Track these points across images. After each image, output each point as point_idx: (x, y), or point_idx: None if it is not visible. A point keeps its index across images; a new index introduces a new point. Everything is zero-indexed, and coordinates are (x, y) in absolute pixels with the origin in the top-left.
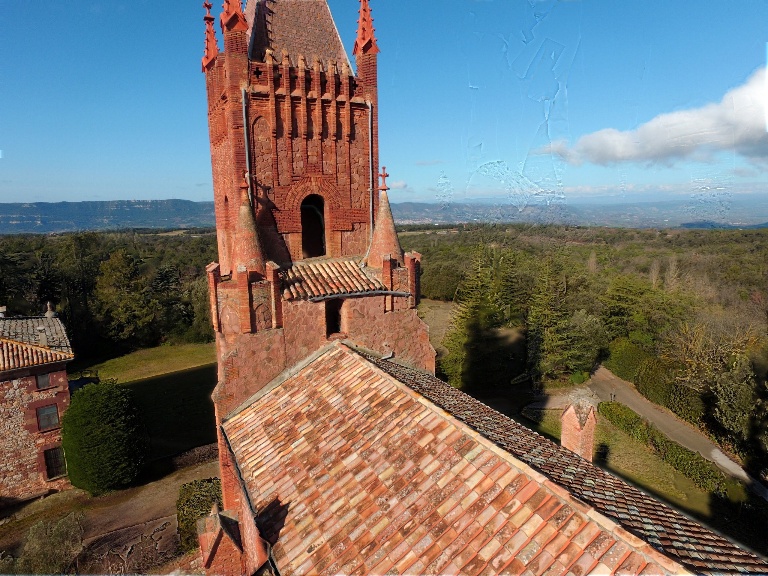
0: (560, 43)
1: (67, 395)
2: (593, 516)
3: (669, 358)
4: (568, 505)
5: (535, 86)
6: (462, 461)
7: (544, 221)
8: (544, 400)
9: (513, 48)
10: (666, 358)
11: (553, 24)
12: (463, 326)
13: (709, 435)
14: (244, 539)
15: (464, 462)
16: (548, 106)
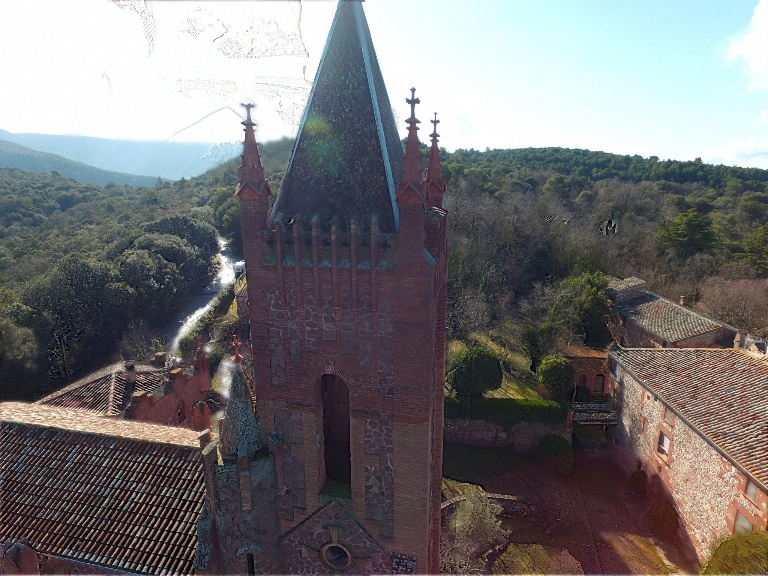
0: None
1: (764, 527)
2: None
3: None
4: None
5: None
6: None
7: None
8: None
9: None
10: None
11: None
12: None
13: None
14: None
15: None
16: None
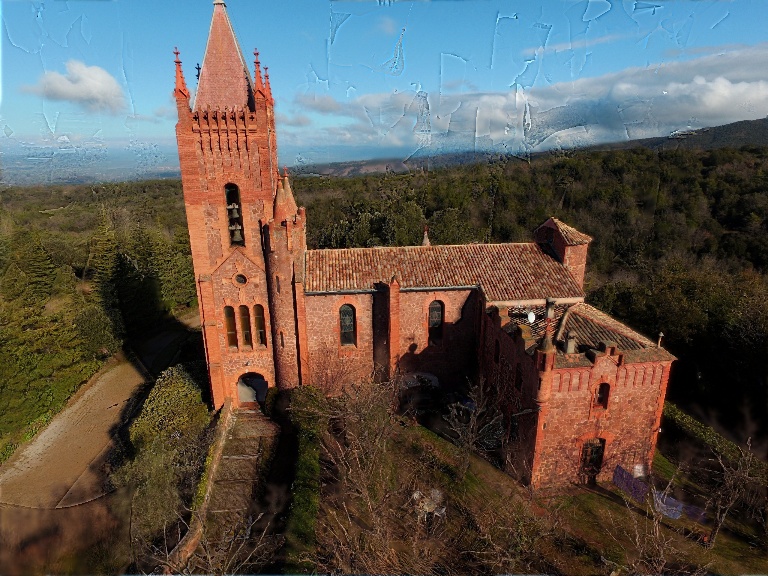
0: (103, 25)
1: None
2: (438, 246)
3: None
4: (433, 247)
5: (49, 49)
6: (407, 252)
7: (124, 186)
8: (193, 321)
9: (85, 27)
10: None
11: (91, 5)
12: (111, 286)
13: None
14: (308, 347)
15: (408, 252)
16: (47, 67)
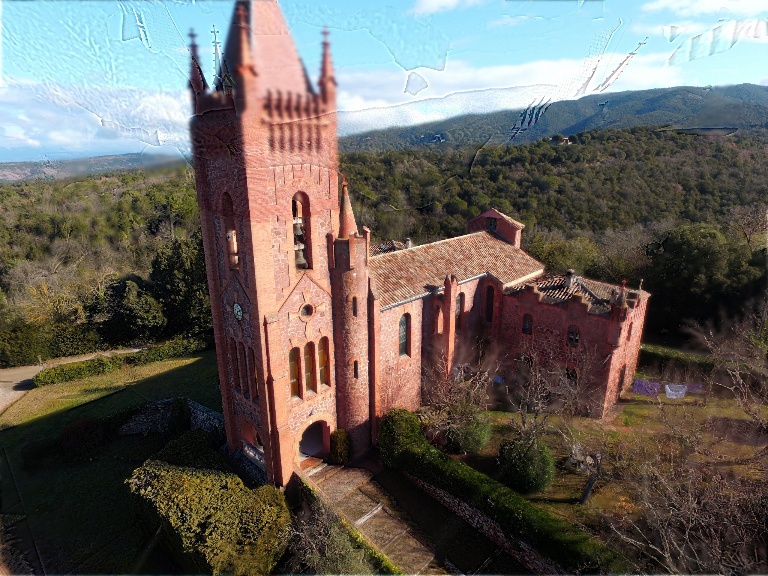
0: None
1: None
2: None
3: (37, 319)
4: None
5: None
6: None
7: None
8: None
9: None
10: (37, 319)
11: None
12: None
13: (116, 348)
14: None
15: None
16: None
